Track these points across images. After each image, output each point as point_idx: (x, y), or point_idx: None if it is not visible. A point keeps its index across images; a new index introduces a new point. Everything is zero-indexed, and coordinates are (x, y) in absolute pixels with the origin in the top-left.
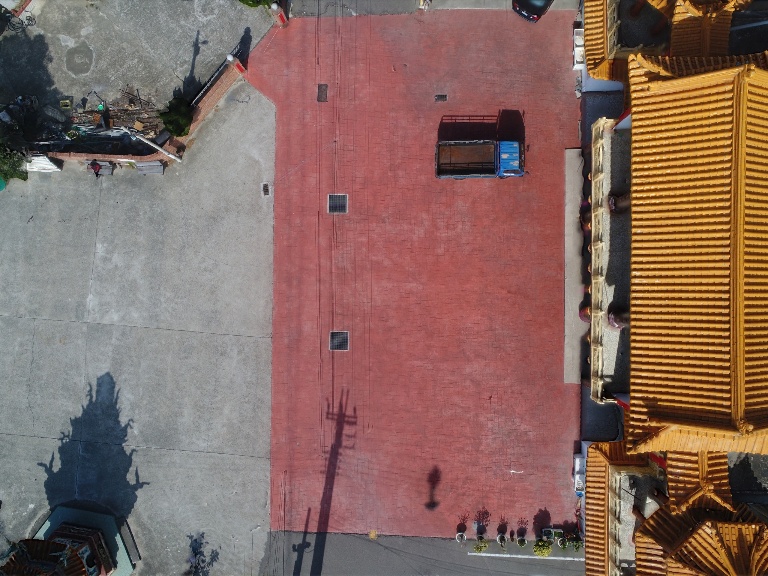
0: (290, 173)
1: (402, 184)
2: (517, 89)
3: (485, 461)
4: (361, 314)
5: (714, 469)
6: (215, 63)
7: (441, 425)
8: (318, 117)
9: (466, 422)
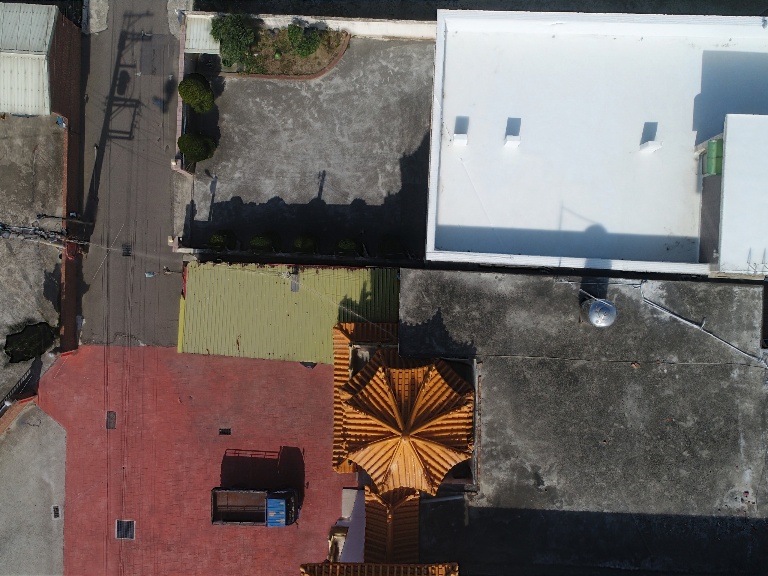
0: (80, 497)
1: (187, 514)
2: (298, 427)
3: None
4: None
5: None
6: (6, 387)
7: None
8: (107, 444)
9: None
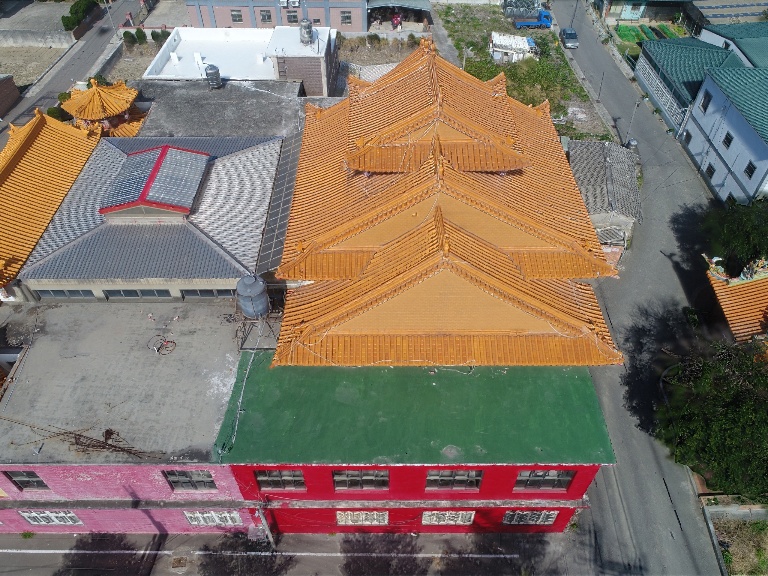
0: None
1: None
2: None
3: None
4: None
5: None
6: None
7: None
8: None
9: None
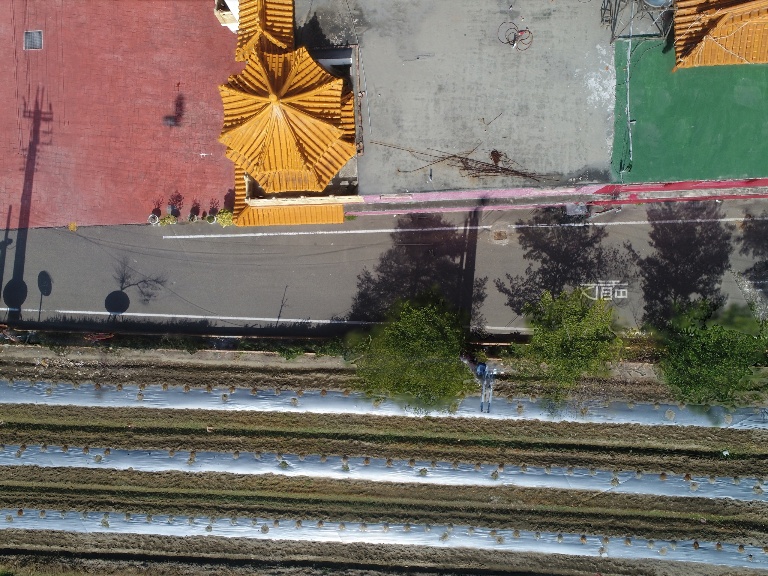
0: None
1: None
2: None
3: (176, 146)
4: (53, 13)
5: (277, 20)
6: None
7: (133, 115)
8: None
9: (156, 110)
